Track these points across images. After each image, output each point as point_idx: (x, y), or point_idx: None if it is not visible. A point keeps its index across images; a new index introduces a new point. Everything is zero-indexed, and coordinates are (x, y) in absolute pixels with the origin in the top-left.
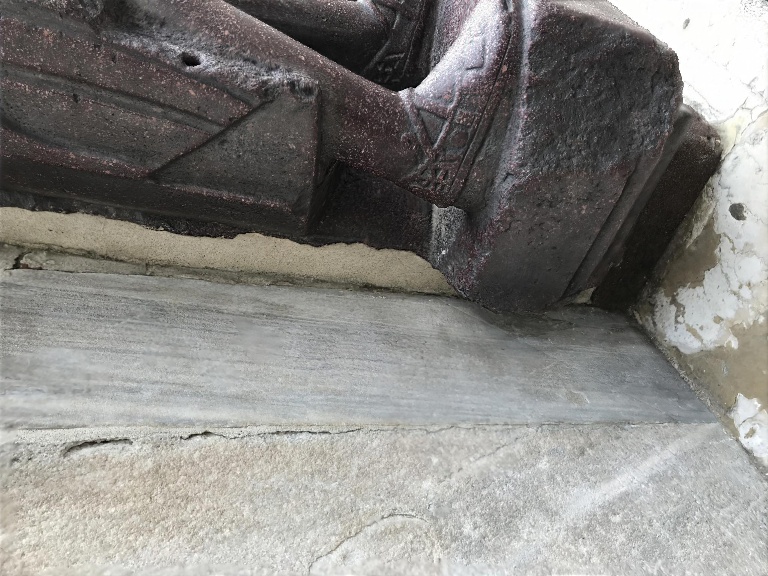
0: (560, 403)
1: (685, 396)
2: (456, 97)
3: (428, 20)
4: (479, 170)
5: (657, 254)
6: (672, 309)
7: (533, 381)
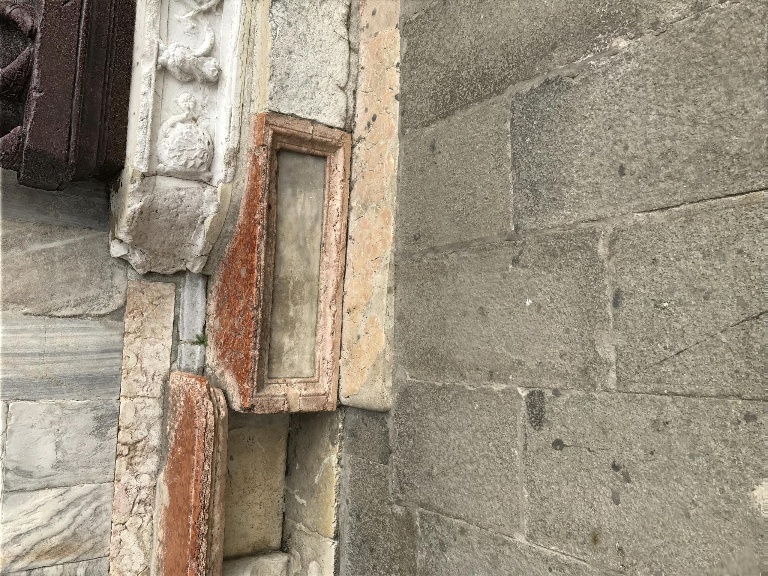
0: (48, 217)
1: (103, 221)
2: (5, 152)
3: (26, 86)
4: (14, 167)
5: (113, 175)
6: (112, 193)
7: (44, 207)
